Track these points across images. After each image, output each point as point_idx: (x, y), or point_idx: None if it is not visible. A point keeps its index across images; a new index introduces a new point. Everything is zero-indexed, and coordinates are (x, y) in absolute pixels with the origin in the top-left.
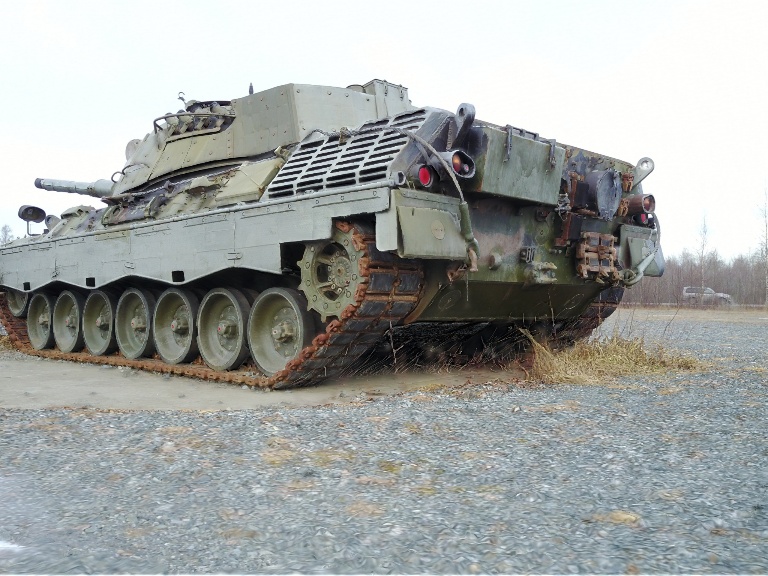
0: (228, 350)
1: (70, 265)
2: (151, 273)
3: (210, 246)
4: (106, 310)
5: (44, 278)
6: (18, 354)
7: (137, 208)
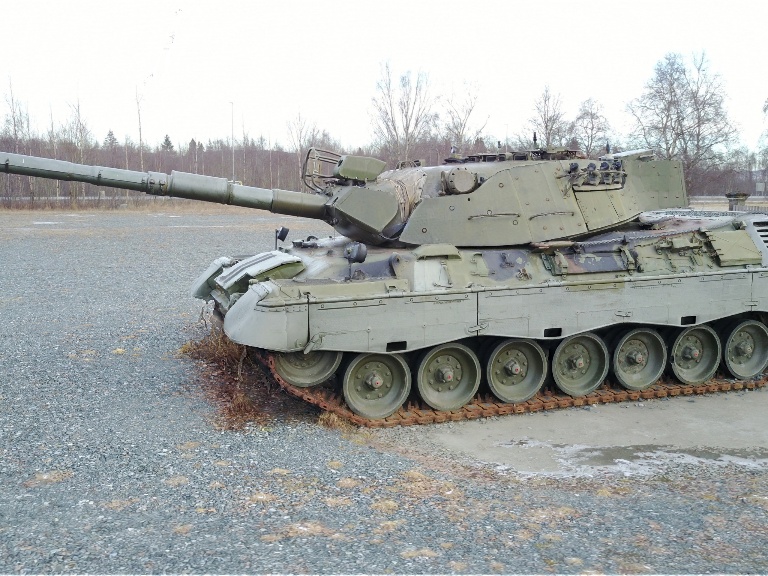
0: (686, 368)
1: (515, 318)
2: (656, 319)
3: (728, 297)
4: (509, 356)
5: (449, 334)
6: (394, 430)
7: (584, 257)
